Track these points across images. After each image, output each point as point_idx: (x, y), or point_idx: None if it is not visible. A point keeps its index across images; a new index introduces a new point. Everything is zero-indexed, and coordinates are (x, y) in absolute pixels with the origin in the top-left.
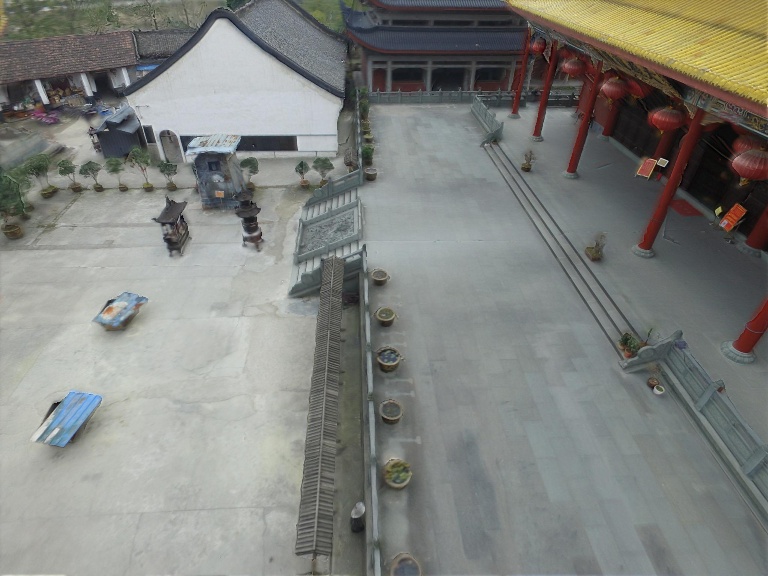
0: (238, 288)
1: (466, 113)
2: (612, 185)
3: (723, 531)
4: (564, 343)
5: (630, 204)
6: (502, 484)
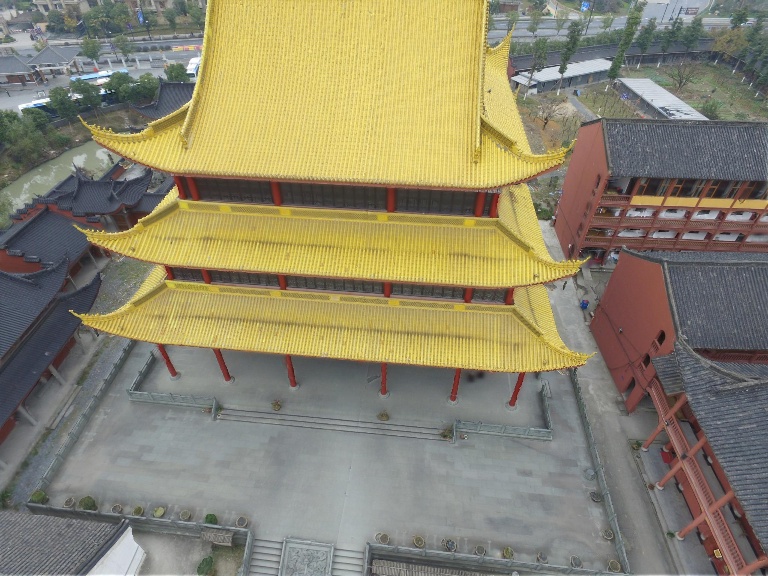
0: None
1: (131, 406)
2: (313, 371)
3: (517, 451)
4: (438, 460)
5: (337, 374)
6: (506, 514)
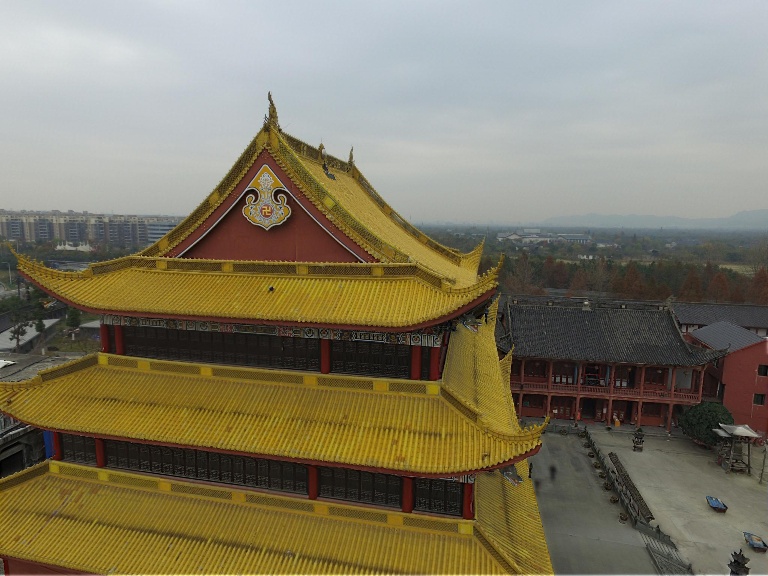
0: (712, 559)
1: None
2: None
3: None
4: None
5: None
6: None
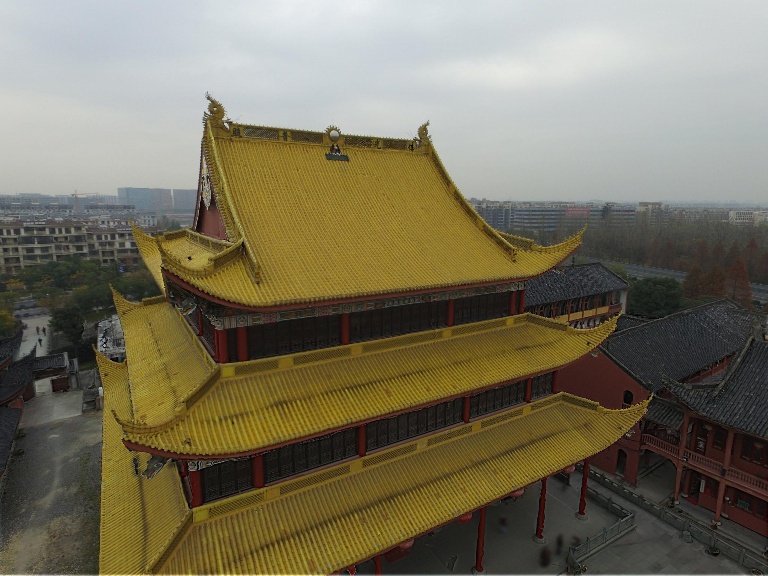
0: None
1: None
2: None
3: None
4: None
5: None
6: None
